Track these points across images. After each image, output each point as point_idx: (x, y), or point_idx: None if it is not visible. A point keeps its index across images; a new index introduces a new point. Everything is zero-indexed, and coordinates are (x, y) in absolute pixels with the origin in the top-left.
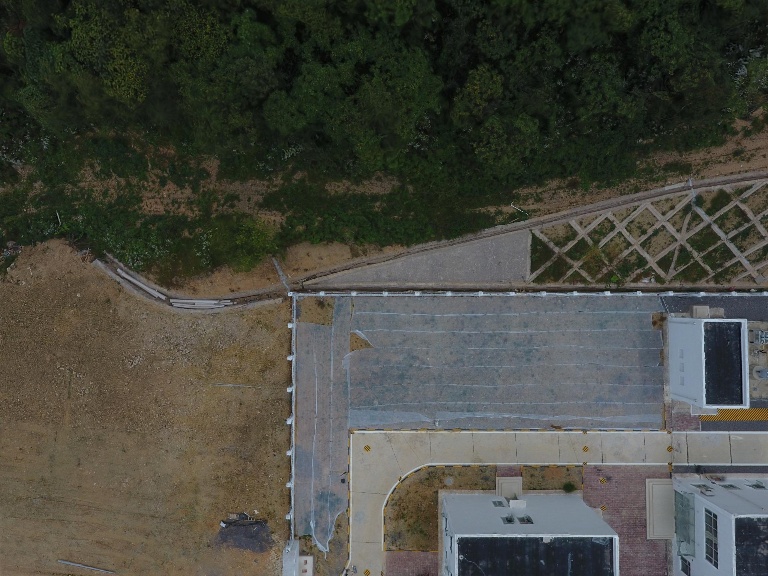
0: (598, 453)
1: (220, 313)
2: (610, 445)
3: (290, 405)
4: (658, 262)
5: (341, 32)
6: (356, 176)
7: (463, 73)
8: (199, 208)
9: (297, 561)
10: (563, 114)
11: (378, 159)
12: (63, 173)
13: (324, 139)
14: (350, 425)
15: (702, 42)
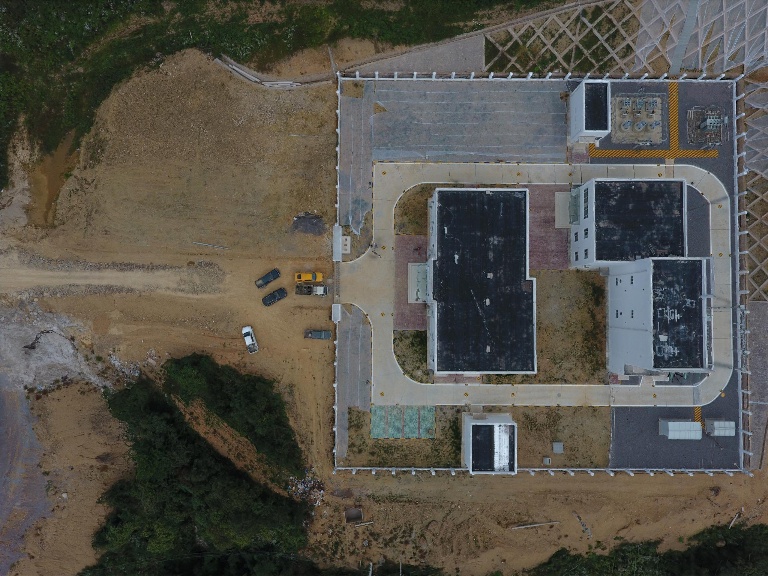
0: (526, 177)
1: (293, 90)
2: (534, 172)
3: None
4: (563, 58)
5: None
6: None
7: None
8: (285, 16)
9: (341, 238)
10: None
11: None
12: (195, 6)
13: None
14: (373, 159)
15: None
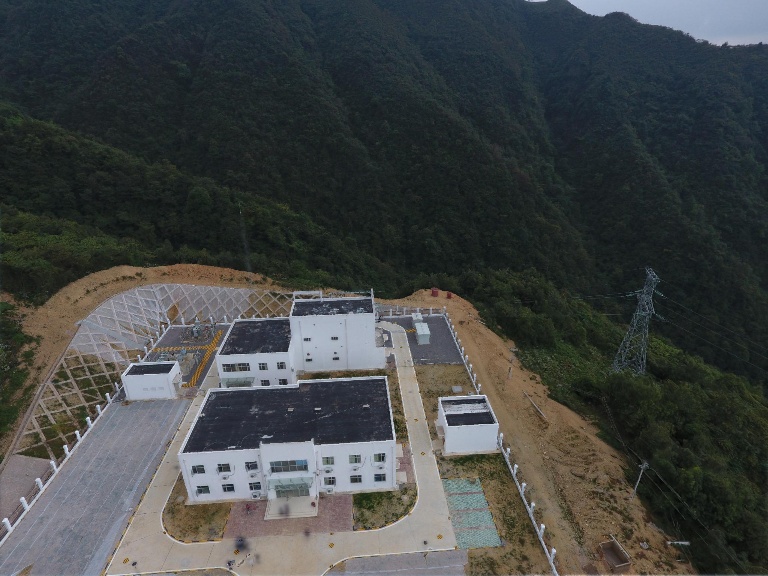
0: None
1: None
2: (192, 419)
3: None
4: (87, 402)
5: None
6: None
7: None
8: None
9: None
10: None
11: None
12: None
13: None
14: None
15: None
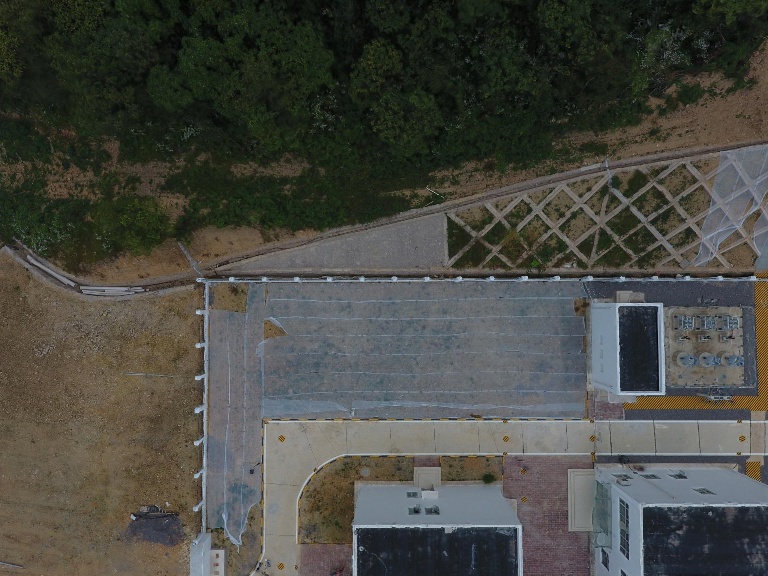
0: (519, 443)
1: (131, 300)
2: (531, 434)
3: (203, 394)
4: (579, 246)
5: (226, 5)
6: (261, 157)
7: (359, 48)
8: (101, 191)
9: (208, 554)
10: (473, 93)
11: (275, 138)
12: None
13: (225, 119)
14: (264, 415)
15: (603, 15)
